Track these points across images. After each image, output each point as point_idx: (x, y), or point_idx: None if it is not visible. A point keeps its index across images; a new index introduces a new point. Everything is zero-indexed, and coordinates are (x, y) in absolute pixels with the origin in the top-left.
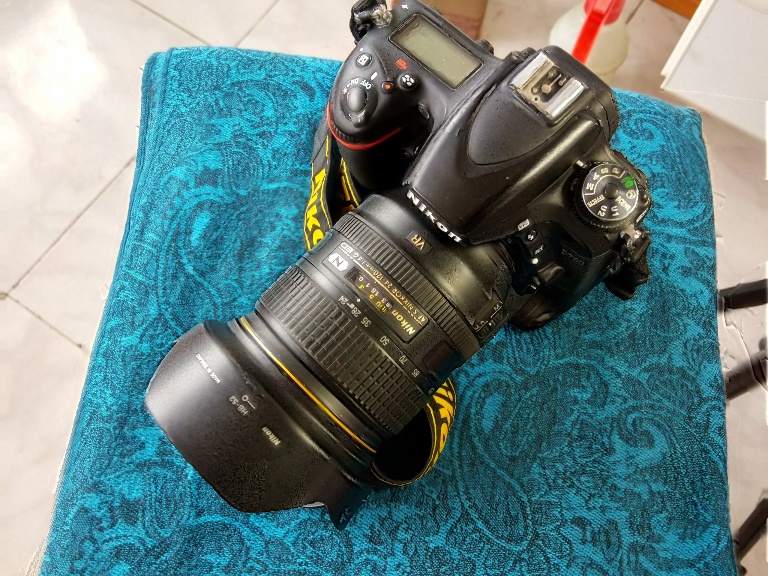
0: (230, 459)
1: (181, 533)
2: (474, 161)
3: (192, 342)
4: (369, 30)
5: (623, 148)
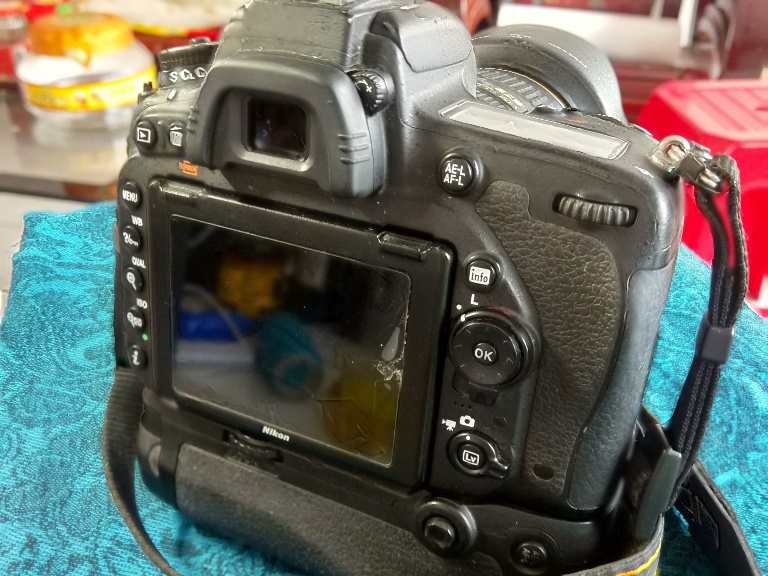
0: None
1: None
2: None
3: None
4: None
5: None
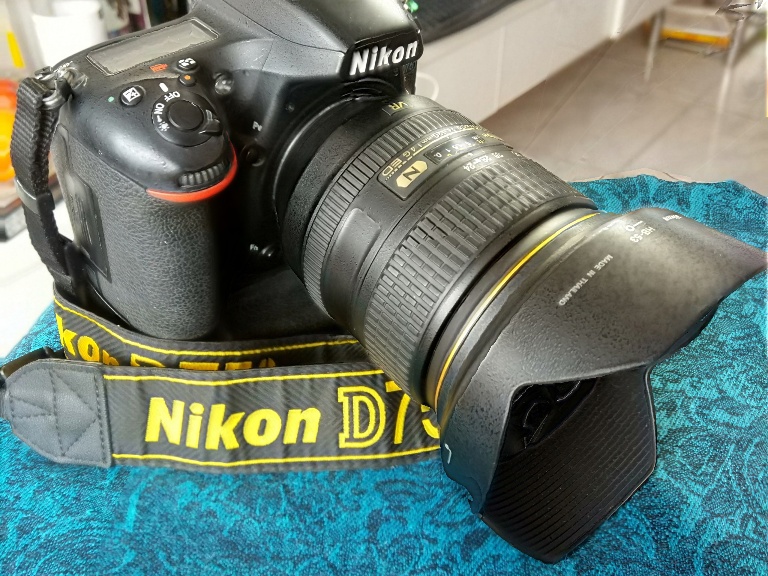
0: (721, 247)
1: None
2: None
3: (528, 336)
4: (78, 100)
5: None
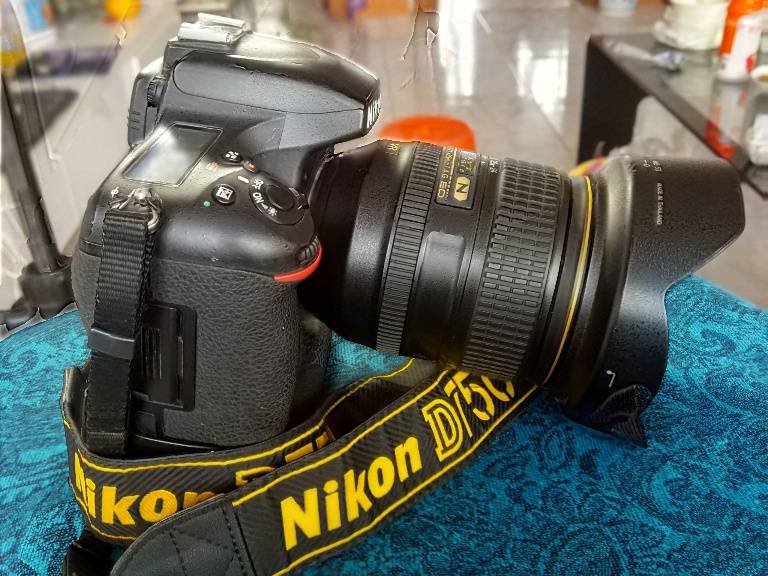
0: None
1: (767, 414)
2: (317, 58)
3: (653, 254)
4: (165, 218)
5: (55, 362)
